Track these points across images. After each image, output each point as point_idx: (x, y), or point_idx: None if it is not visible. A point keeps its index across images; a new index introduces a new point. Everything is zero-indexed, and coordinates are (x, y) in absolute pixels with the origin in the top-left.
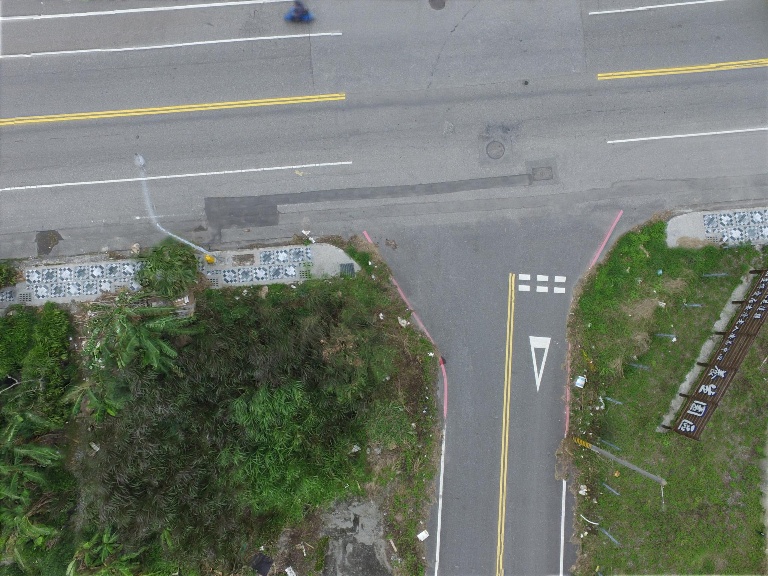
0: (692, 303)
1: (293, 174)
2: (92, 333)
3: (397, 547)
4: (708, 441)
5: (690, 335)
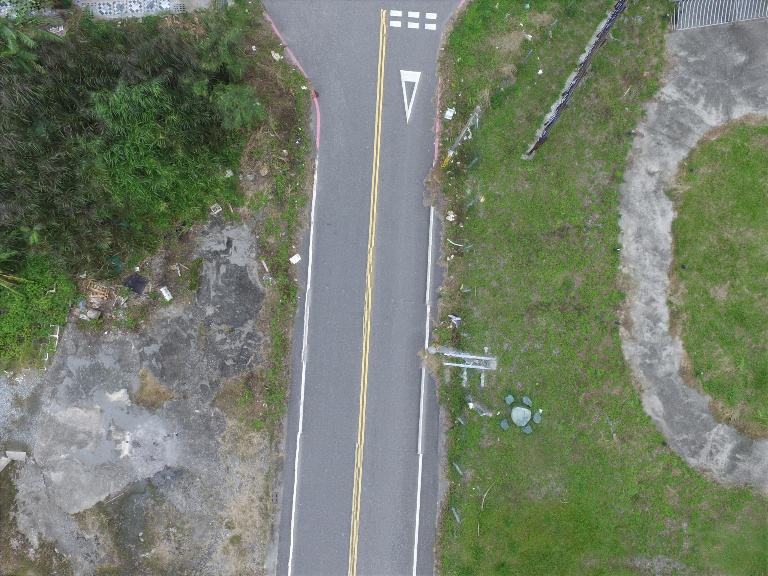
0: (558, 36)
1: None
2: None
3: (268, 267)
4: (570, 167)
5: (556, 68)
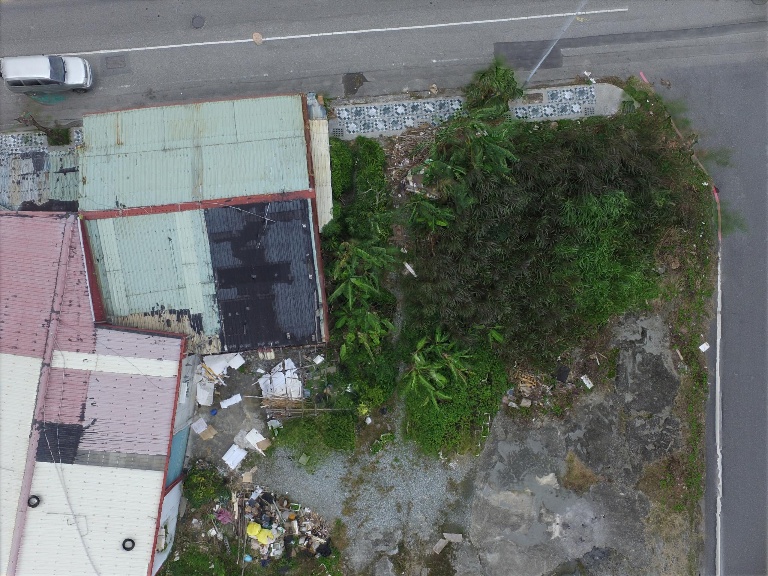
0: None
1: (574, 20)
2: (400, 164)
3: (684, 356)
4: None
5: None
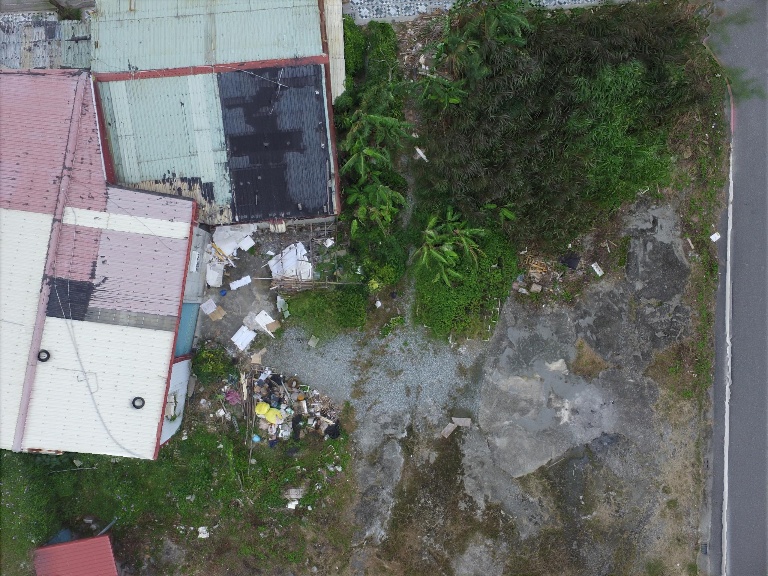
0: None
1: None
2: (412, 50)
3: (694, 244)
4: None
5: None
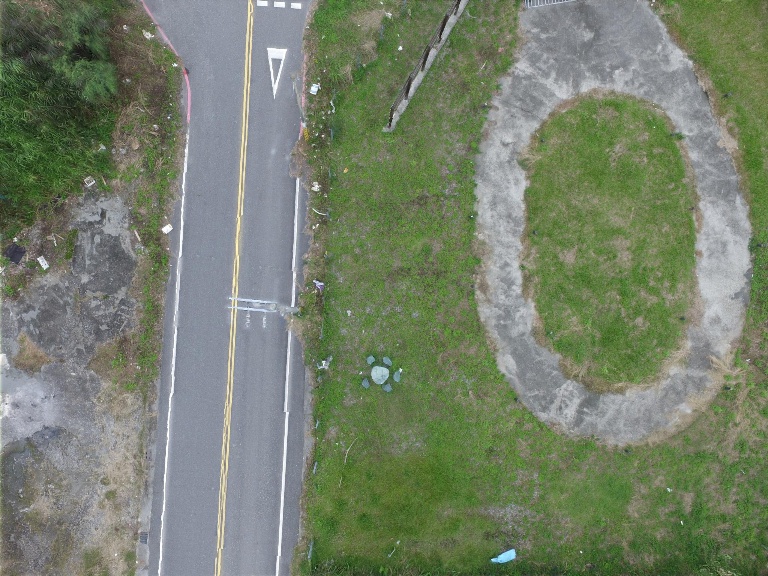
0: (417, 14)
1: None
2: None
3: (140, 236)
4: (428, 139)
5: (415, 44)
